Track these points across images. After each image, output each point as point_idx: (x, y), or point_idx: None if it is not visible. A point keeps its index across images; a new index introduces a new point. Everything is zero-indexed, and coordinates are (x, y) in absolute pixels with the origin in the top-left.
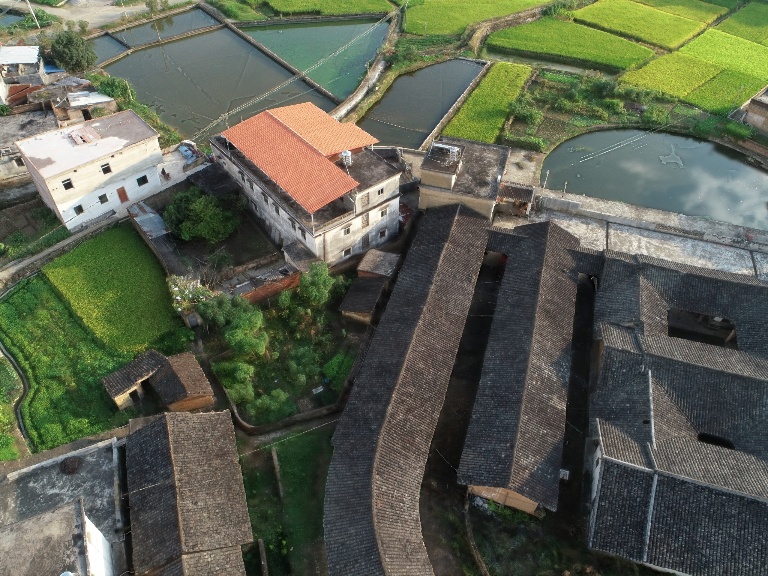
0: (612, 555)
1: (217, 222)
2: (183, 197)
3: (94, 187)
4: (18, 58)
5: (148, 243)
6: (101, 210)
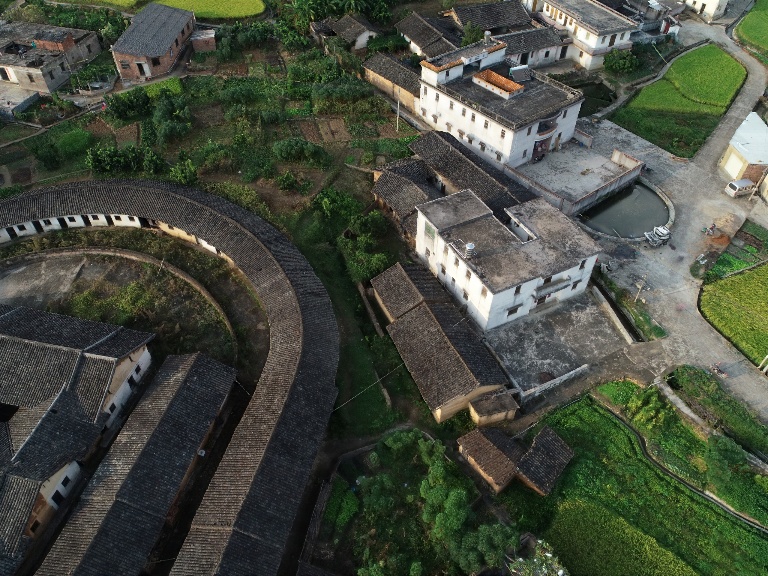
0: None
1: None
2: None
3: None
4: None
5: None
6: None
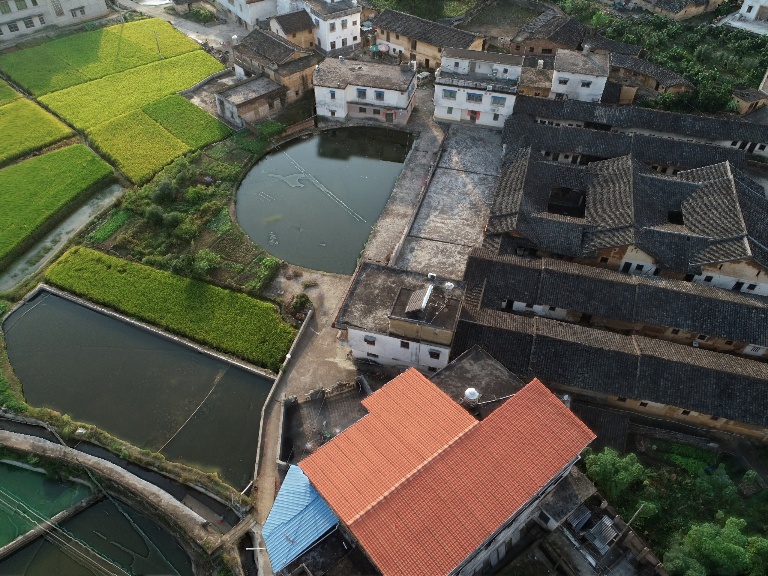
0: None
1: None
2: None
3: None
4: None
5: None
6: None
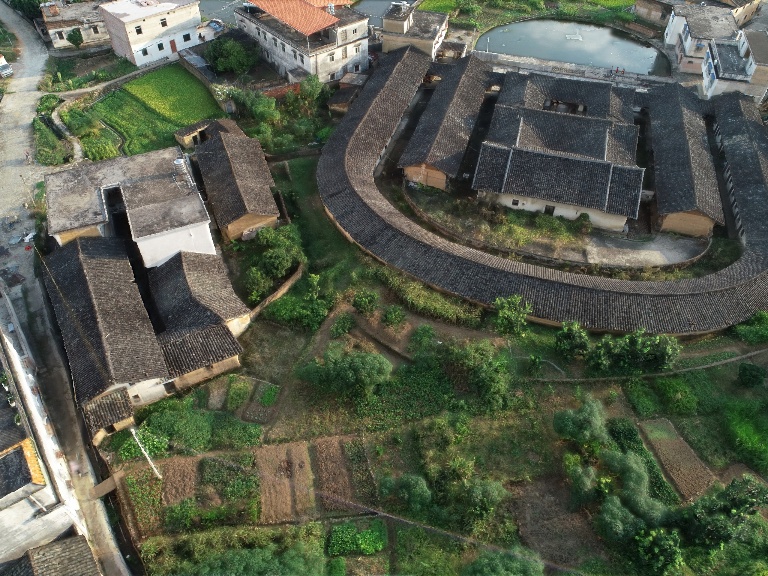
0: (488, 200)
1: (242, 57)
2: (218, 42)
3: (155, 36)
4: None
5: (194, 73)
6: (159, 56)
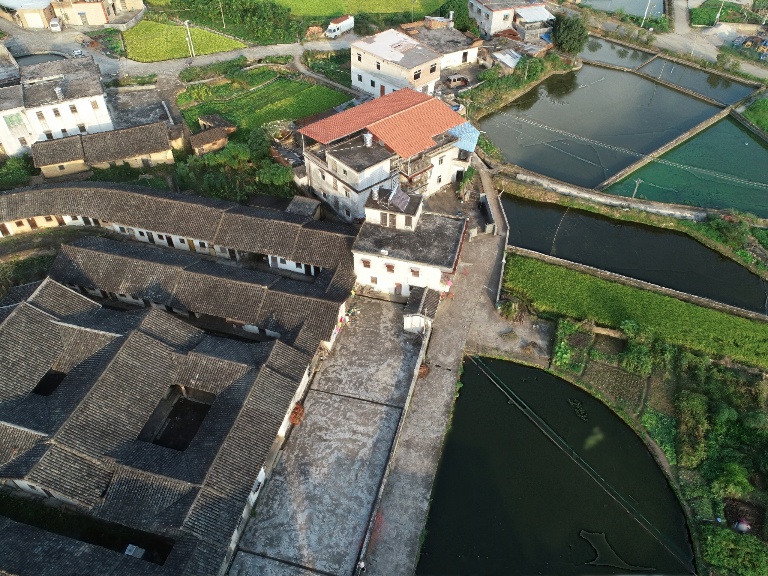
0: None
1: None
2: None
3: (370, 71)
4: (529, 15)
5: None
6: (370, 89)
